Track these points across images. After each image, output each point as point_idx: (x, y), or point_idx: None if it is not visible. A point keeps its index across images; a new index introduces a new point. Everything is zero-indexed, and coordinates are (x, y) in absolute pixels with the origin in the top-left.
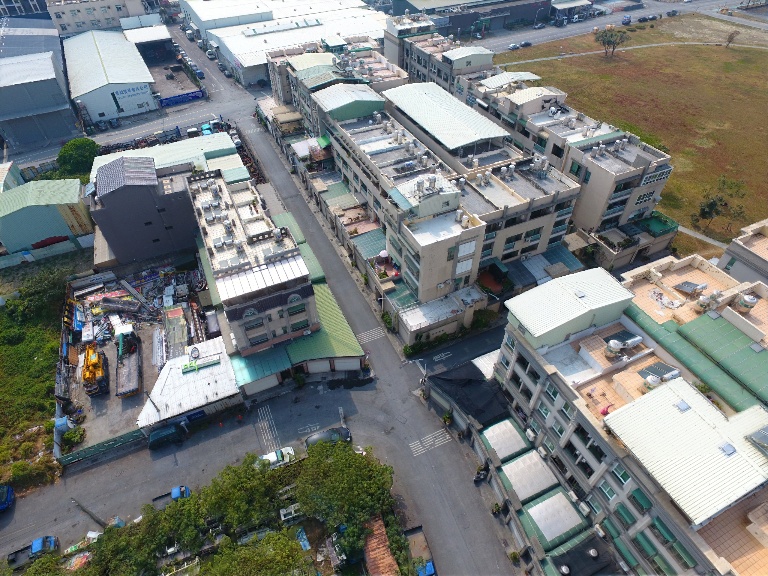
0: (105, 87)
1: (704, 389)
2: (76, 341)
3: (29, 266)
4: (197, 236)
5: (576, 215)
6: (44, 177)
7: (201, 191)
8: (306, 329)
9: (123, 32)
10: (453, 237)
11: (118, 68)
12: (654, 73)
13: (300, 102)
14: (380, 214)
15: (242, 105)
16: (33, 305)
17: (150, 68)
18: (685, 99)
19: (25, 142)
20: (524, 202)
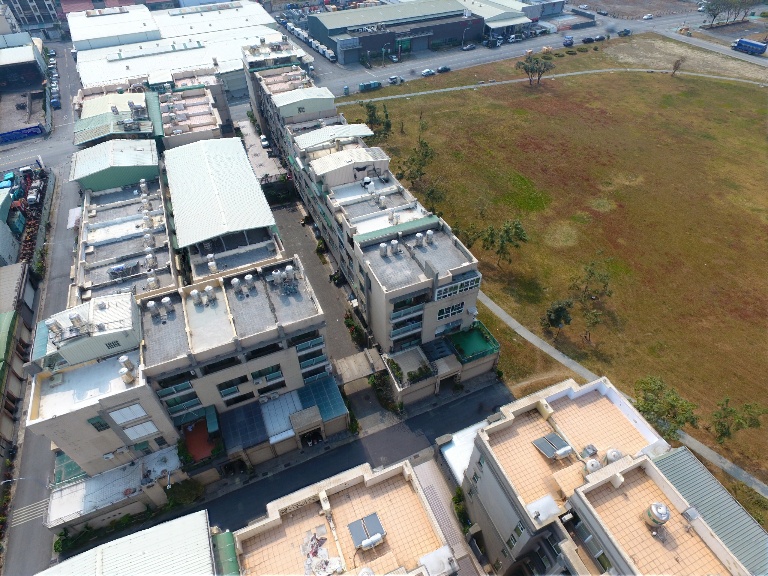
0: None
1: None
2: None
3: None
4: None
5: (373, 325)
6: None
7: None
8: None
9: None
10: (86, 407)
11: None
12: (578, 108)
13: None
14: None
15: None
16: None
17: (8, 95)
18: (601, 143)
19: None
20: (225, 343)
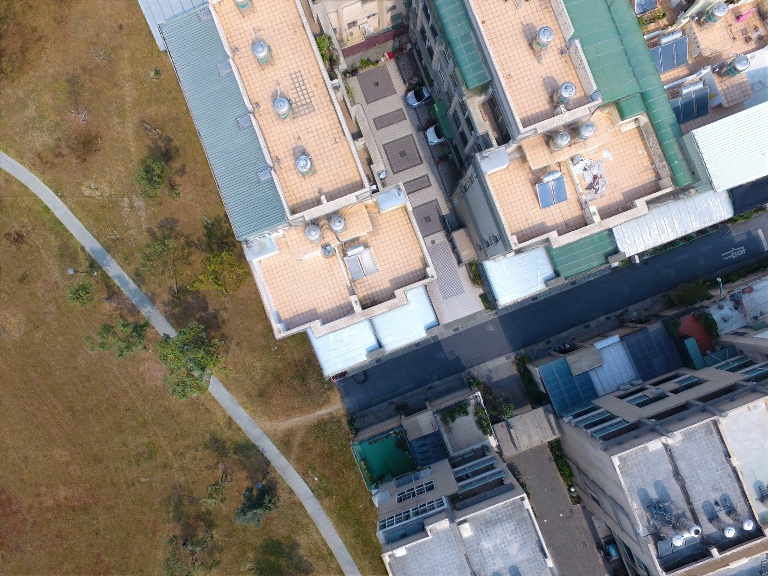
0: None
1: (640, 19)
2: None
3: None
4: None
5: None
6: None
7: None
8: None
9: None
10: None
11: None
12: None
13: None
14: None
15: None
16: None
17: None
18: None
19: None
20: None
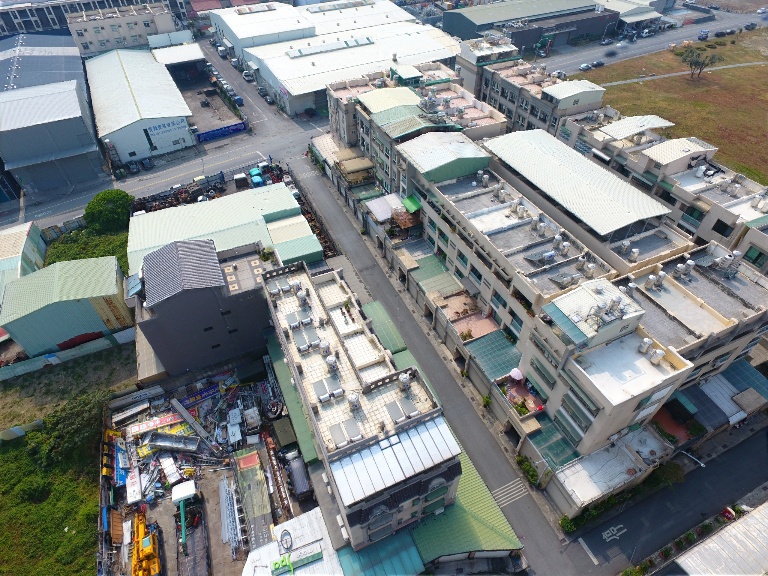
0: (137, 123)
1: None
2: (118, 498)
3: (54, 371)
4: (268, 341)
5: None
6: (69, 239)
7: (282, 295)
8: (439, 507)
9: (151, 51)
10: (652, 387)
11: (150, 98)
12: (754, 100)
13: (371, 147)
14: (503, 314)
15: (291, 140)
16: (62, 447)
17: (181, 92)
18: None
19: (45, 189)
20: (731, 325)
